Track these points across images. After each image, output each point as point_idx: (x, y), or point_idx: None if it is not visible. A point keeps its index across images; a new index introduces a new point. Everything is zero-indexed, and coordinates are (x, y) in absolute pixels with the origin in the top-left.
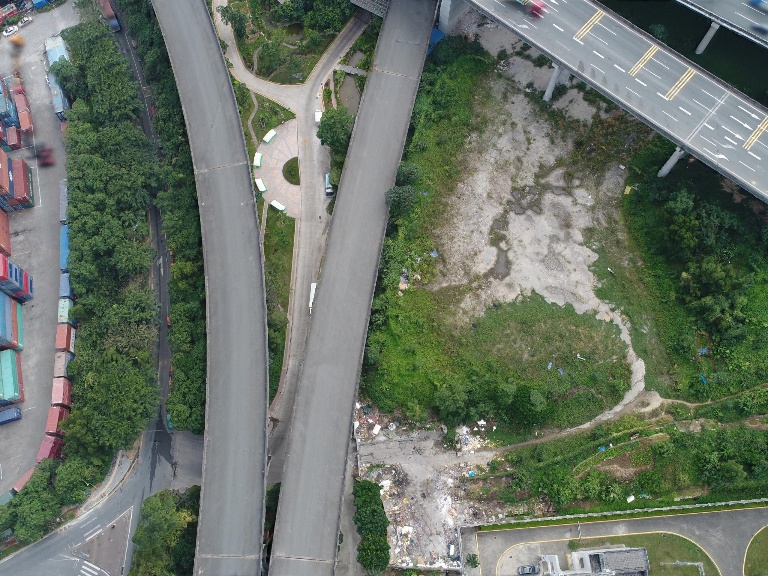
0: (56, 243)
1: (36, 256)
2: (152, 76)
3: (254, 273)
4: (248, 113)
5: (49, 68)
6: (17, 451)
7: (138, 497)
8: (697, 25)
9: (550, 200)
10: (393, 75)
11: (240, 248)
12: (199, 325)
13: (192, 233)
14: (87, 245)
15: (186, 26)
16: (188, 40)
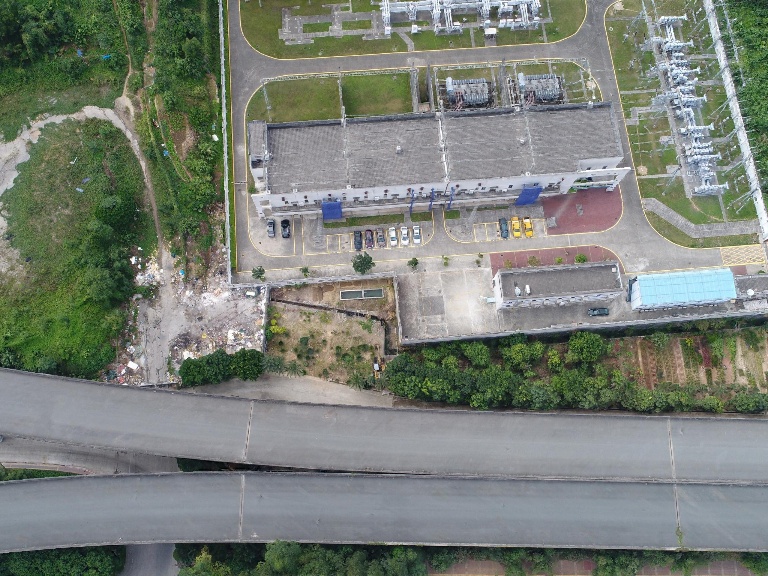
0: None
1: None
2: None
3: None
4: None
5: None
6: None
7: None
8: None
9: None
10: None
11: None
12: None
13: None
14: None
15: None
16: None
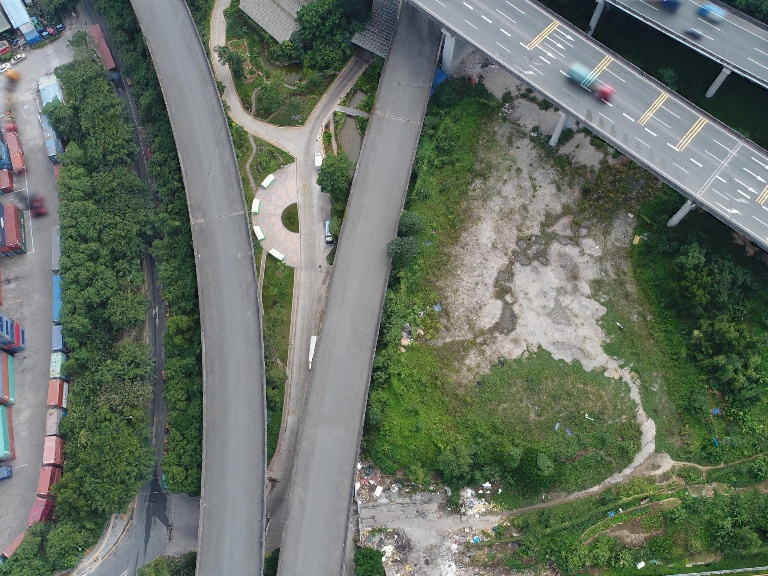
0: (49, 291)
1: (28, 305)
2: (148, 118)
3: (252, 329)
4: (246, 157)
5: (42, 109)
6: (8, 511)
7: (132, 561)
8: (707, 68)
9: (557, 250)
10: (395, 119)
11: (237, 302)
12: (195, 382)
13: (188, 284)
14: (80, 298)
15: (182, 68)
16: (184, 83)
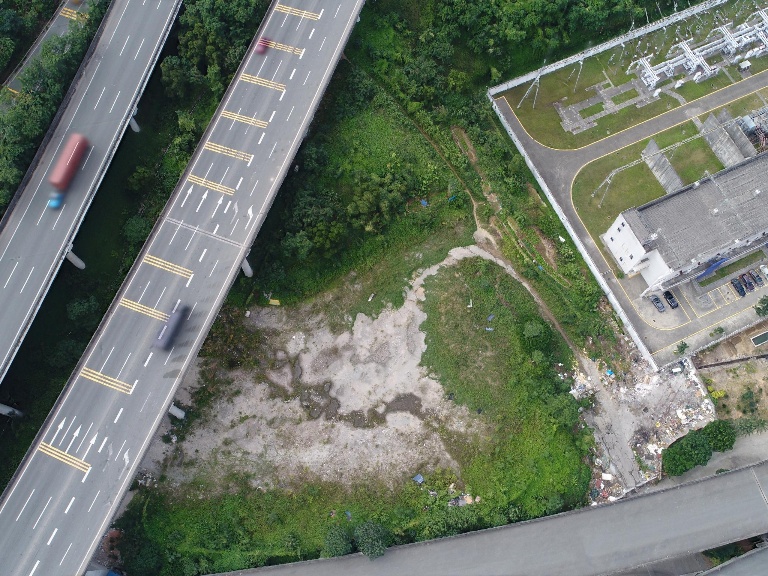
0: None
1: None
2: None
3: None
4: None
5: None
6: None
7: None
8: None
9: (311, 376)
10: None
11: None
12: None
13: None
14: None
15: None
16: None
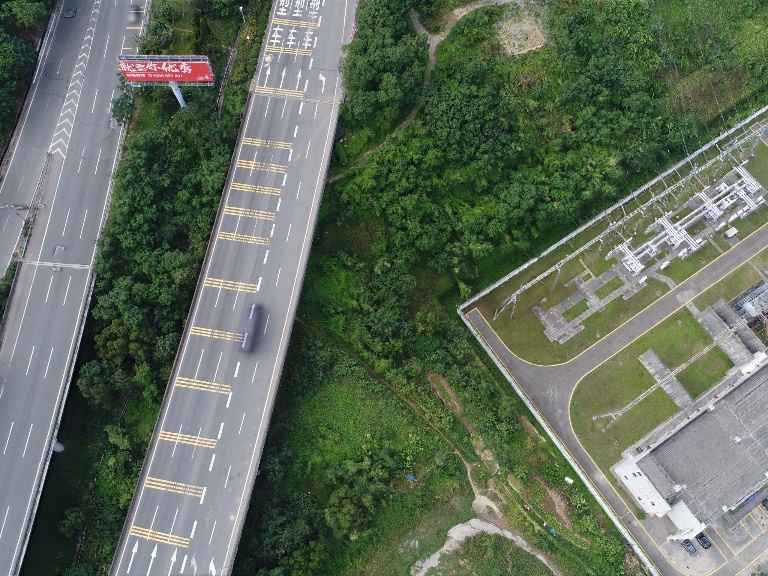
0: None
1: None
2: None
3: None
4: None
5: None
6: None
7: None
8: None
9: None
10: None
11: None
12: None
13: None
14: None
15: None
16: None
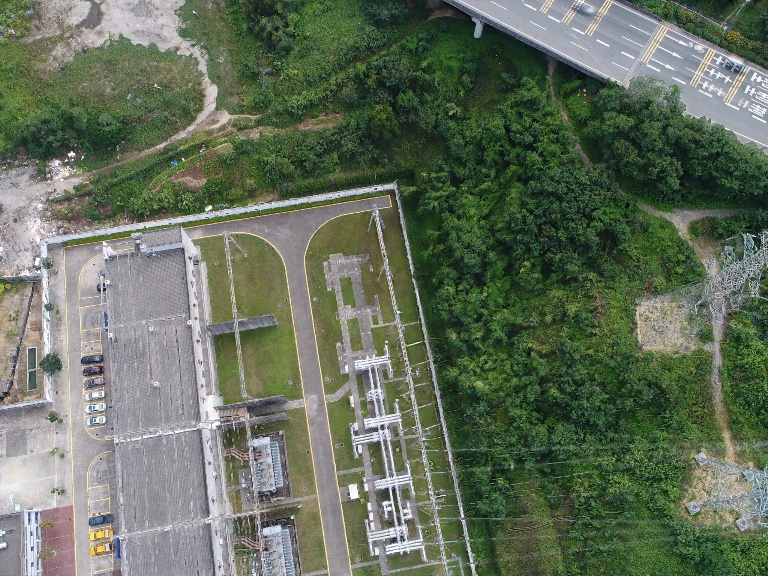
0: None
1: None
2: None
3: None
4: None
5: None
6: None
7: None
8: None
9: None
10: None
11: None
12: None
13: None
14: None
15: None
16: None
